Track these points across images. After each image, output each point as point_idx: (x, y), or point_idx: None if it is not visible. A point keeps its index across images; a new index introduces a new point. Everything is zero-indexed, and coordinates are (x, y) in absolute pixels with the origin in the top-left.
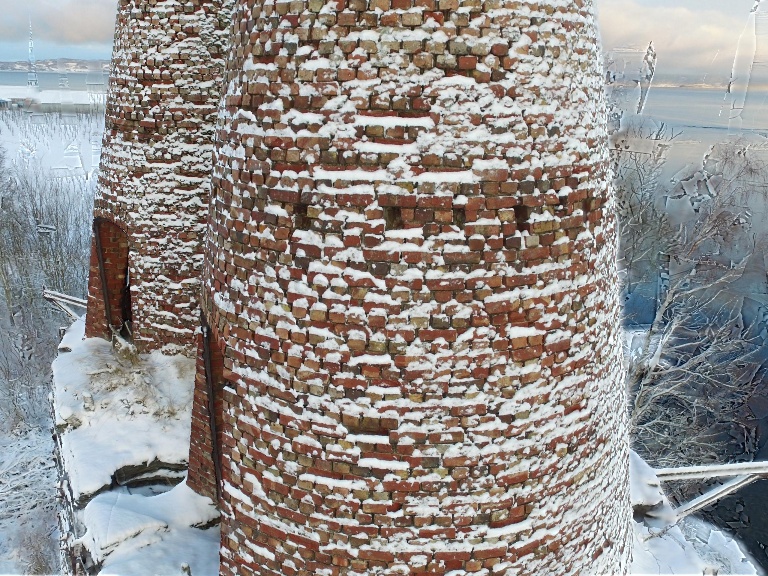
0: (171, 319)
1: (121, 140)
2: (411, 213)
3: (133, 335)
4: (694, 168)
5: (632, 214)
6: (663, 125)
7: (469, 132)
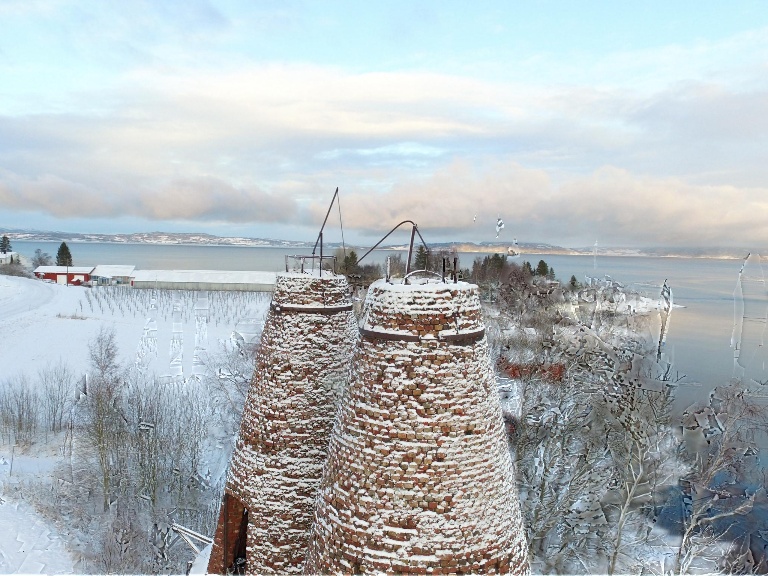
0: (271, 572)
1: (250, 450)
2: (407, 574)
3: None
4: (703, 404)
5: (650, 443)
6: (669, 368)
7: (434, 537)
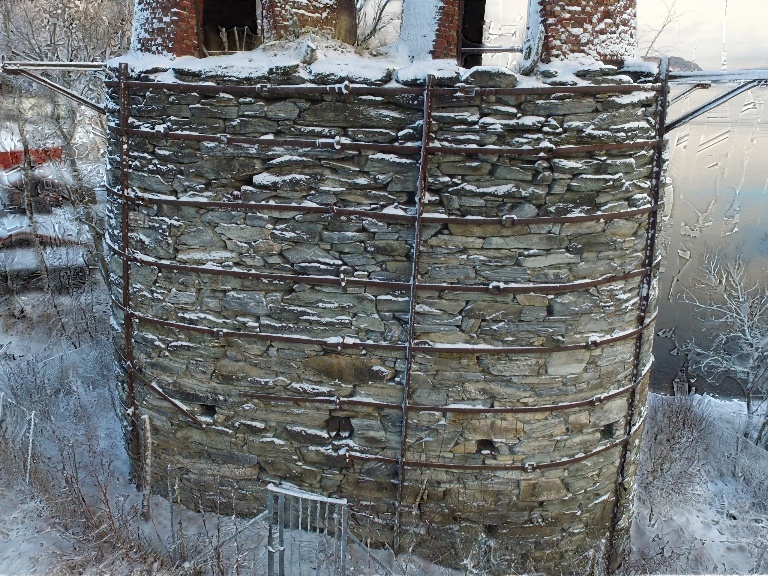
0: (306, 5)
1: None
2: None
3: (276, 21)
4: None
5: None
6: None
7: None
